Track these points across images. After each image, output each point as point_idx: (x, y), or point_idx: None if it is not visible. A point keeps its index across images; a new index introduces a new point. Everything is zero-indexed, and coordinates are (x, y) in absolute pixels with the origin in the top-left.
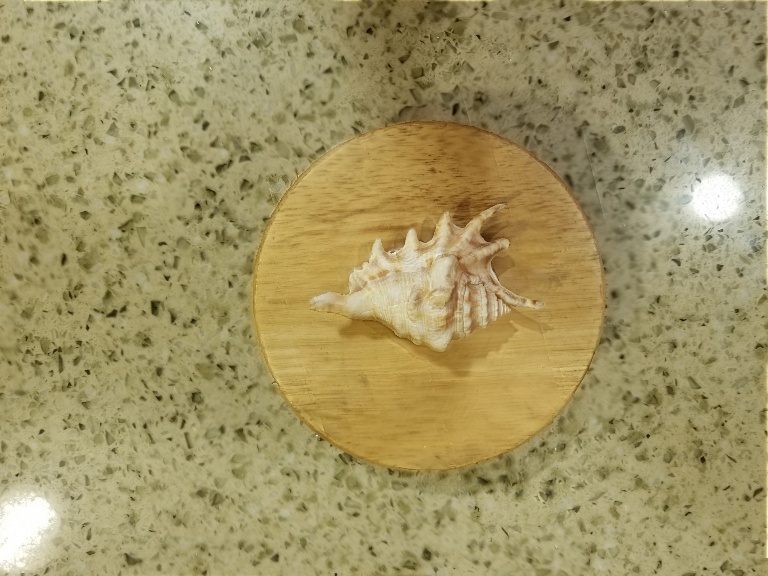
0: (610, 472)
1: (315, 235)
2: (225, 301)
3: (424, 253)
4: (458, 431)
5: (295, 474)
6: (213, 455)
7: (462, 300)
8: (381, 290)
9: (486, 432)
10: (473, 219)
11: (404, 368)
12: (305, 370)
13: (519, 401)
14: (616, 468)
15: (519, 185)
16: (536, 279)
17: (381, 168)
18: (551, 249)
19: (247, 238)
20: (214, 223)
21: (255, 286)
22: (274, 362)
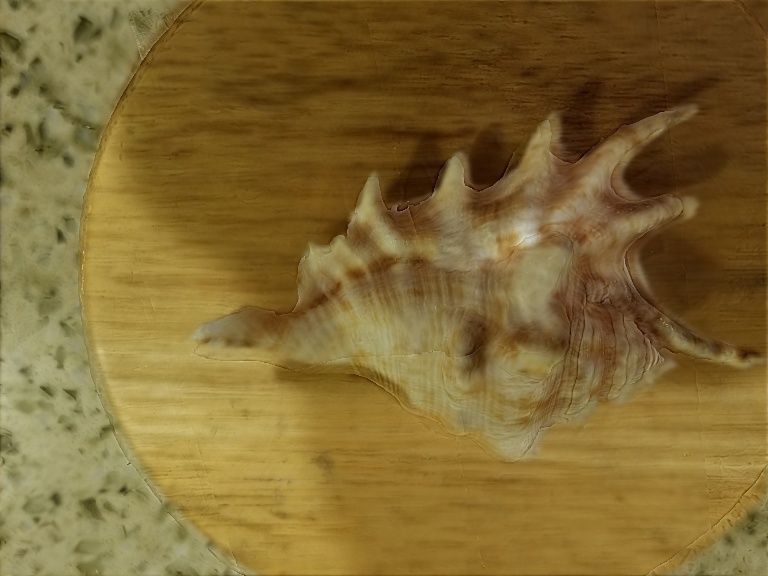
0: (723, 575)
1: (221, 156)
2: (50, 269)
3: (483, 222)
4: (506, 567)
5: (192, 572)
6: (41, 541)
7: (577, 351)
8: (377, 314)
9: (559, 569)
10: (601, 144)
11: (408, 451)
12: (197, 448)
13: (631, 516)
14: (733, 569)
15: (699, 68)
16: (703, 281)
17: (385, 1)
18: (744, 219)
19: (92, 144)
20: (19, 108)
21: (80, 266)
22: (128, 431)
